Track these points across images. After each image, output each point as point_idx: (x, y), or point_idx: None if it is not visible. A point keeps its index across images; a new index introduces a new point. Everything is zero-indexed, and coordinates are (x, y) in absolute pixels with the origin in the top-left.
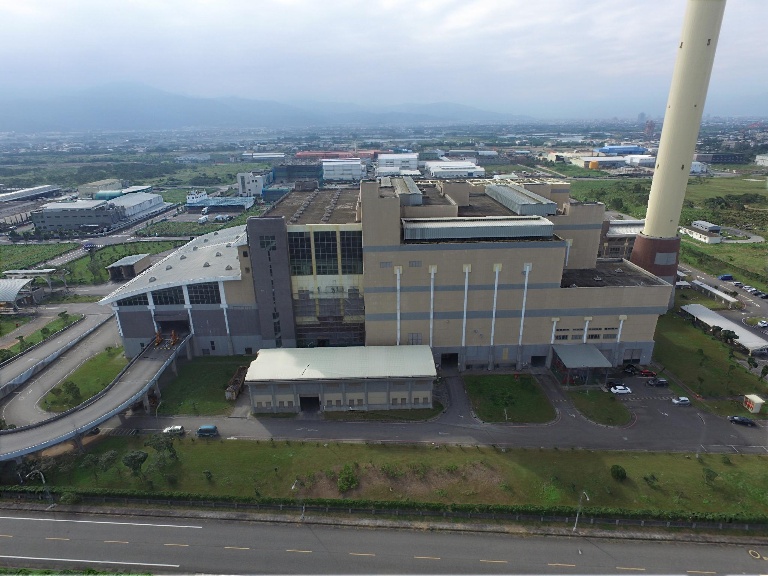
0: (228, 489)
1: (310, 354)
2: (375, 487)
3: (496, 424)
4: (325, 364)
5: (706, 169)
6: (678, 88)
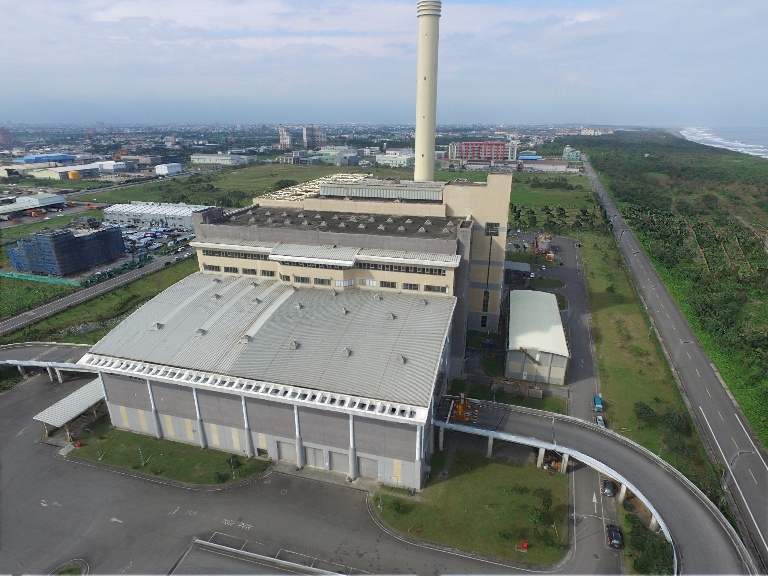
0: (662, 394)
1: (527, 326)
2: (639, 345)
3: (567, 307)
4: (545, 322)
5: (182, 169)
6: (428, 105)
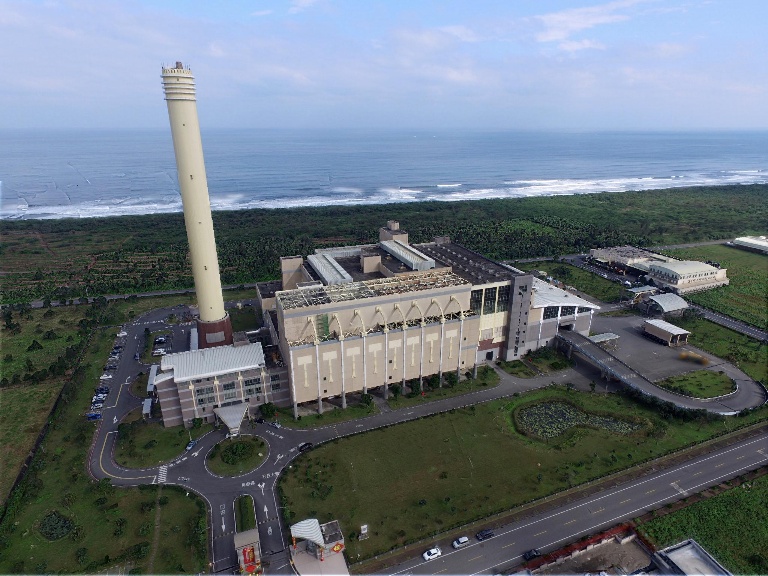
0: None
1: None
2: None
3: None
4: None
5: None
6: None
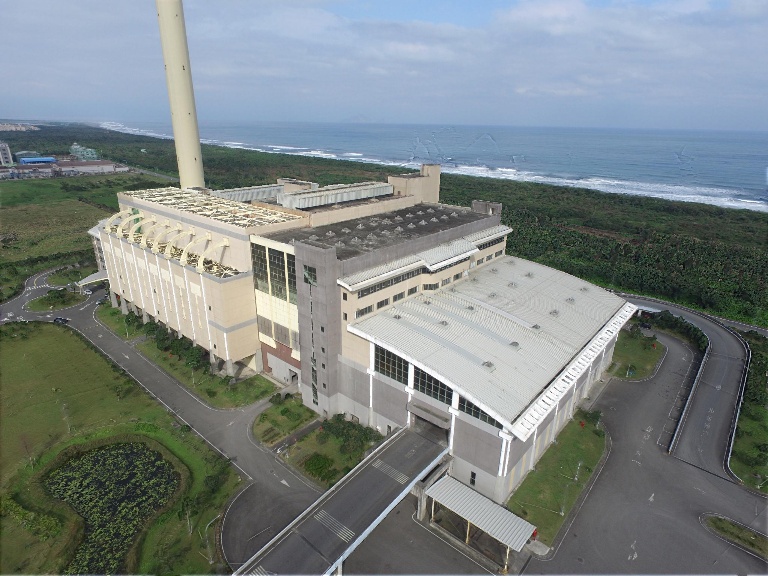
0: None
1: None
2: None
3: None
4: None
5: None
6: None
